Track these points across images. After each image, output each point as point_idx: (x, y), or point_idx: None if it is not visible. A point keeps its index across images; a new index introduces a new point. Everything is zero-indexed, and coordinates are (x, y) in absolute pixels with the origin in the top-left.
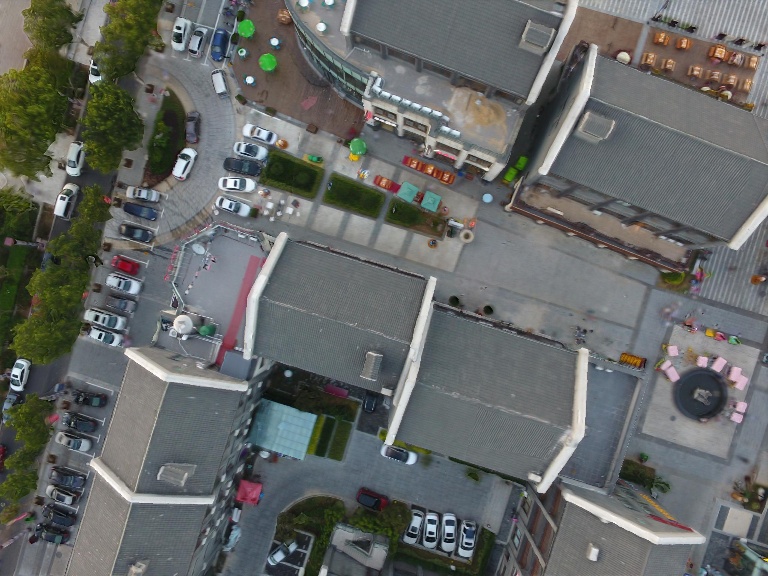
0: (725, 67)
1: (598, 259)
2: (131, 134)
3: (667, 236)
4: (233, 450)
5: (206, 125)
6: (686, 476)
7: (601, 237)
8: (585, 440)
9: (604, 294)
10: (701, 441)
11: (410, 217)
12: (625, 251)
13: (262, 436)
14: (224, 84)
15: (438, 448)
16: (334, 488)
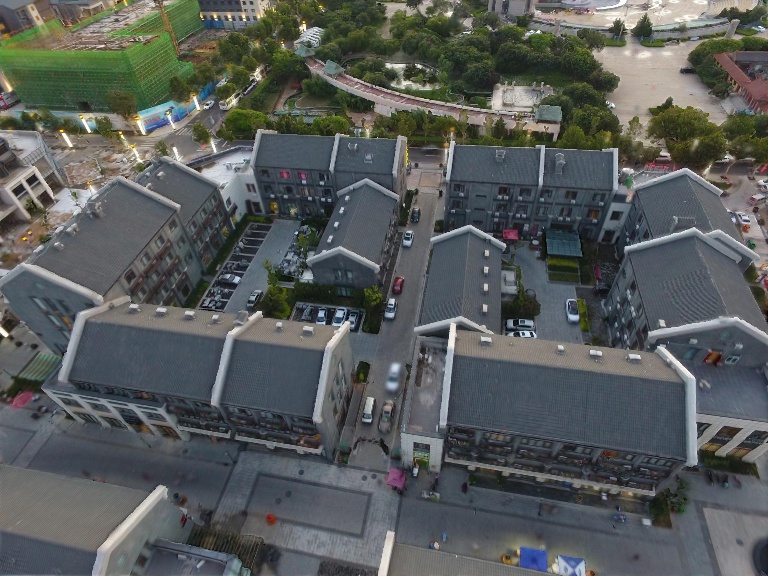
0: None
1: None
2: (704, 159)
3: None
4: (555, 206)
5: (724, 199)
6: (685, 567)
7: None
8: (697, 388)
9: None
10: None
11: (758, 296)
12: None
13: (553, 234)
14: (760, 199)
15: (640, 273)
16: (526, 280)
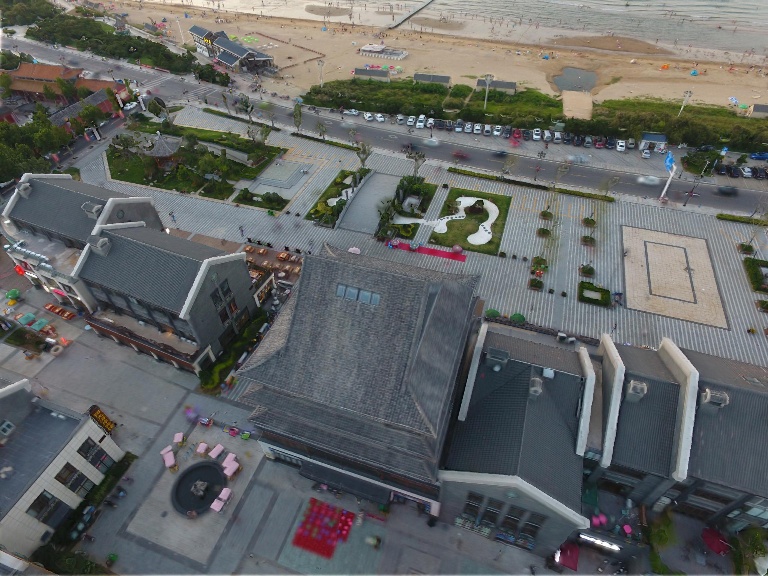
0: (288, 263)
1: (156, 370)
2: None
3: (186, 337)
4: None
5: None
6: None
7: (139, 339)
8: (3, 483)
9: (149, 397)
10: (184, 541)
11: (22, 337)
12: (154, 349)
13: None
14: None
15: None
16: None
